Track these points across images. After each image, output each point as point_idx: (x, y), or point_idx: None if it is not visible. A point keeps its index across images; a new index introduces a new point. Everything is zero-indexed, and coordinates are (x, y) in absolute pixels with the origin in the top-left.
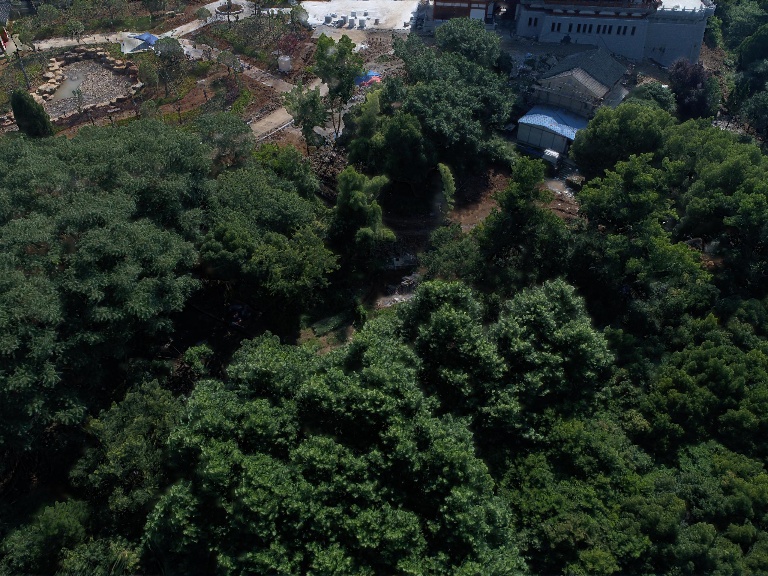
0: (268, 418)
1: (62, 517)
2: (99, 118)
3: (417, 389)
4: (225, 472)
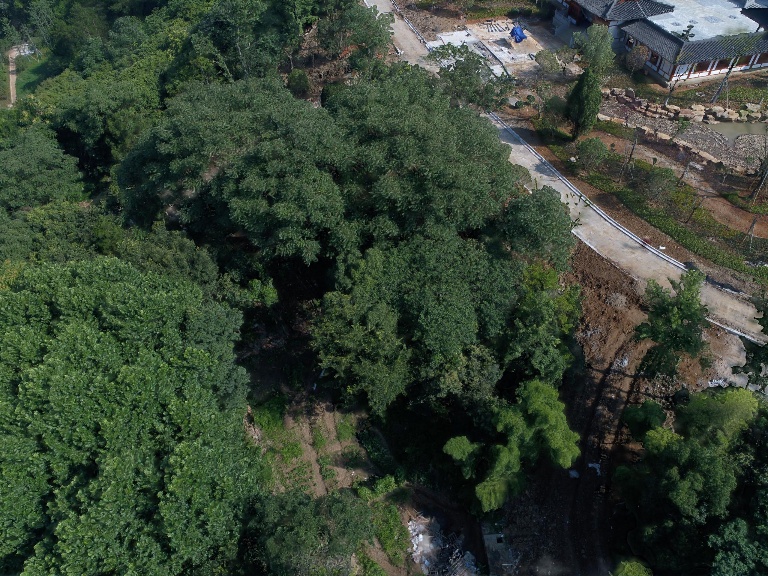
0: (59, 301)
1: (101, 232)
2: (670, 158)
3: (84, 456)
4: (26, 281)
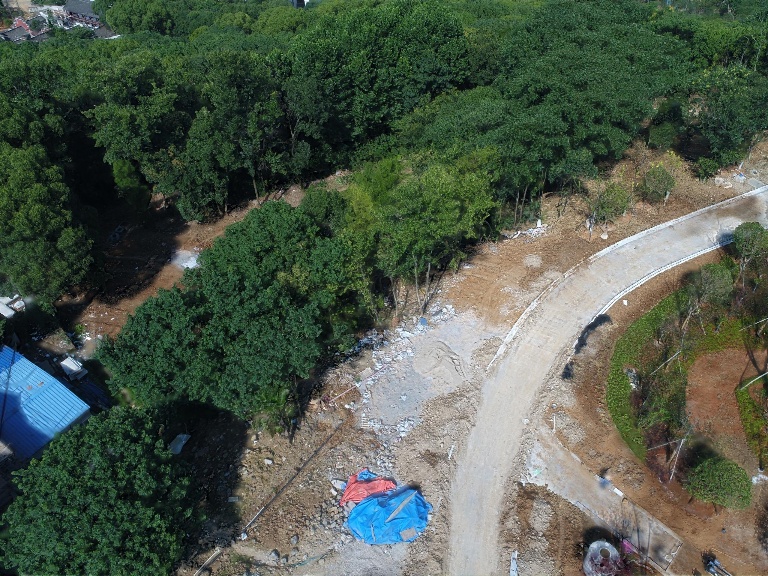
0: (414, 7)
1: None
2: None
3: None
4: None
